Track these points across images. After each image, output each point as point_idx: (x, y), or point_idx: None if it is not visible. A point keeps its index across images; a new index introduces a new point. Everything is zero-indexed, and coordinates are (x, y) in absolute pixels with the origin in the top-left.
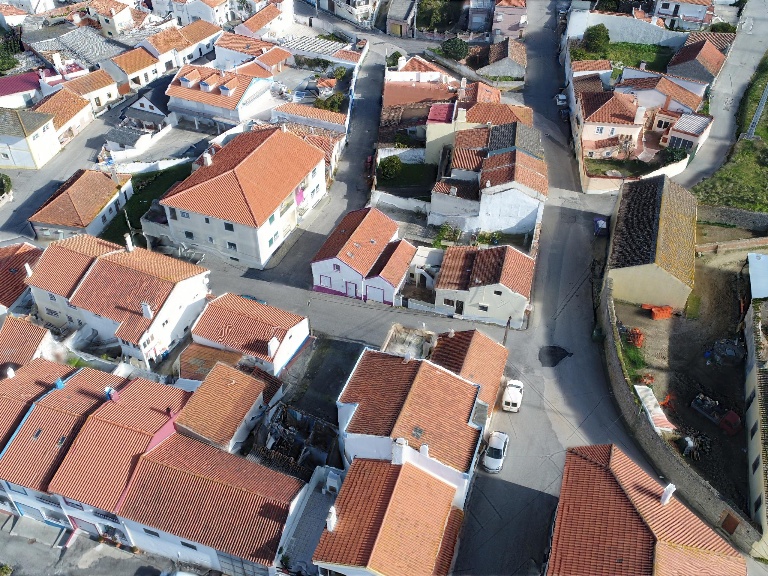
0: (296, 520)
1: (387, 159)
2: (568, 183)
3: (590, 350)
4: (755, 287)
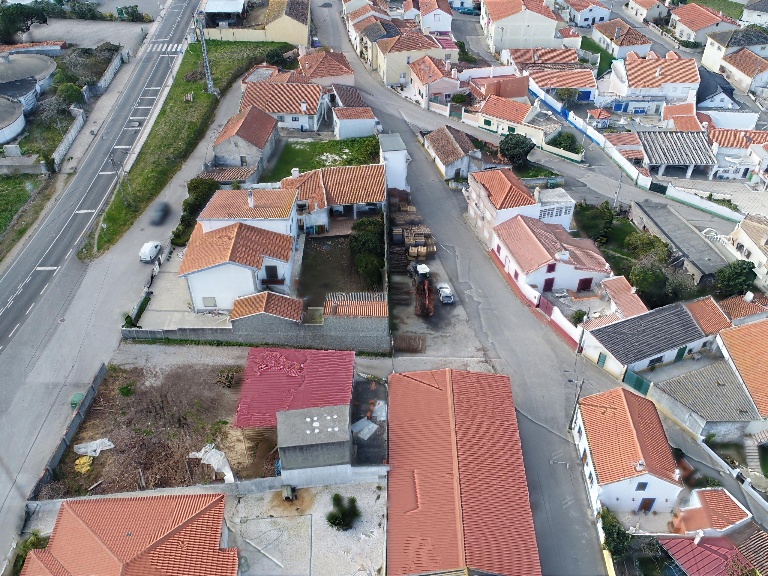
0: None
1: None
2: None
3: None
4: (242, 3)
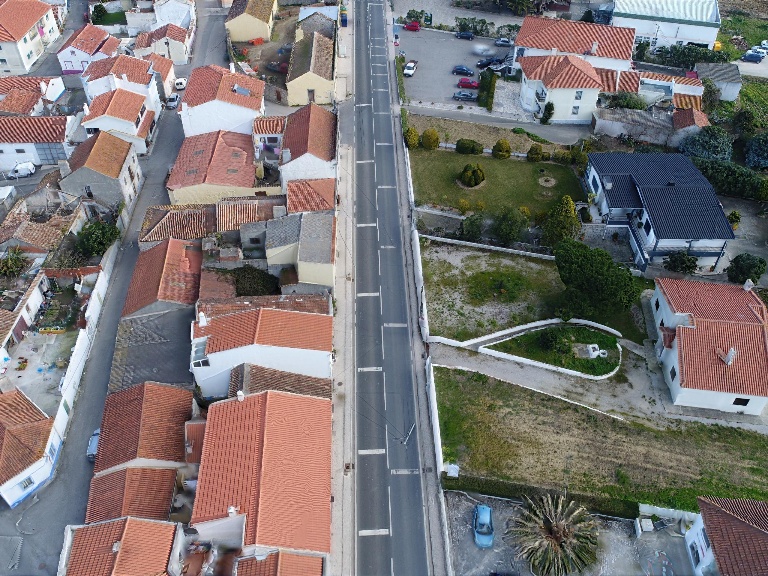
0: (73, 129)
1: (95, 6)
2: (214, 5)
3: (223, 64)
4: (301, 19)
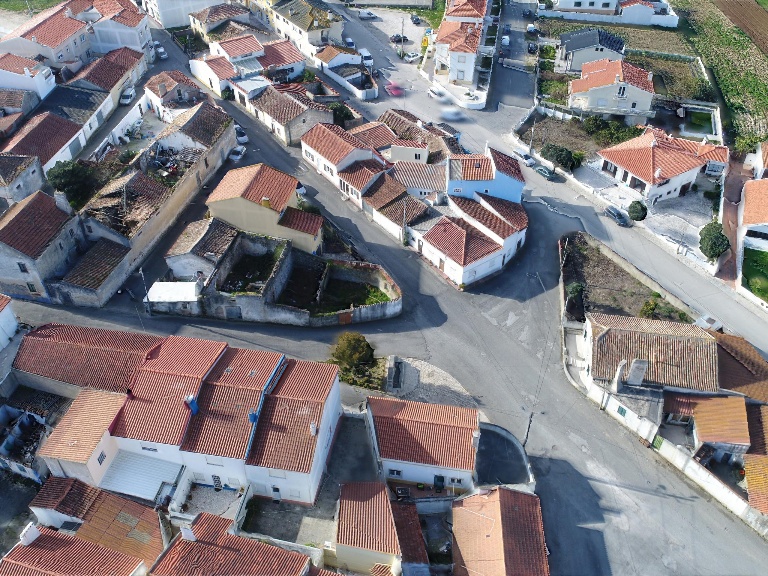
0: None
1: None
2: None
3: None
4: None
